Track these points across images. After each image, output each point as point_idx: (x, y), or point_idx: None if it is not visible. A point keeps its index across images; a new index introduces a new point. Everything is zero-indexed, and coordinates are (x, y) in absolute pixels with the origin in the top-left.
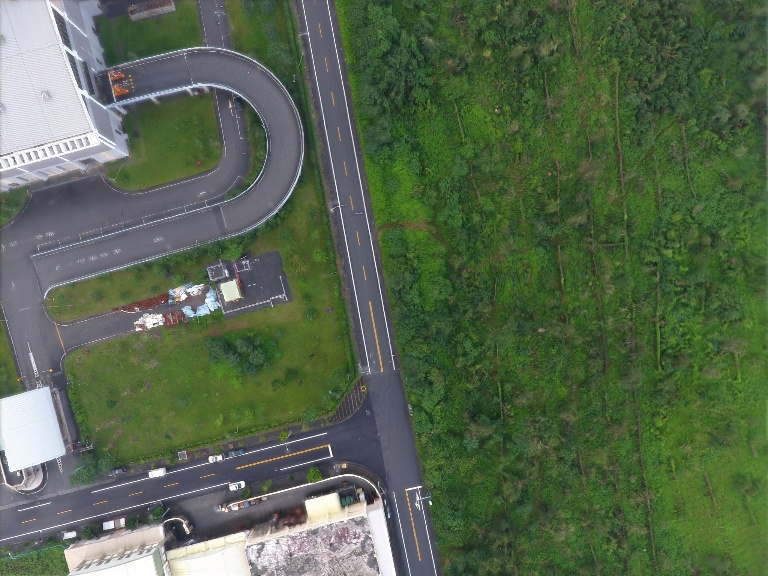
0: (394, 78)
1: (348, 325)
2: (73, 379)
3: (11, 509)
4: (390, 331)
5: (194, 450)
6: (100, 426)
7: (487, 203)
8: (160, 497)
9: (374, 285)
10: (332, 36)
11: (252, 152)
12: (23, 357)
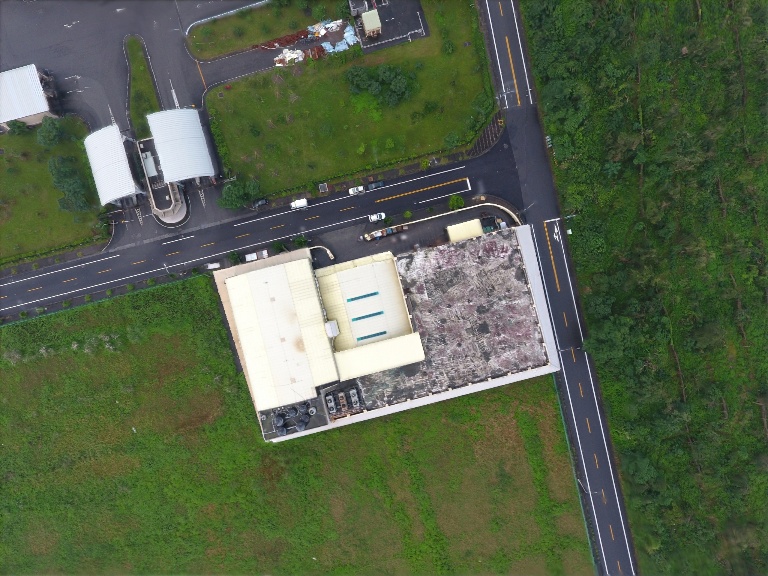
0: None
1: (486, 58)
2: (215, 113)
3: (155, 242)
4: (527, 65)
5: (334, 183)
6: None
7: None
8: (301, 230)
9: (510, 20)
10: None
11: None
12: (165, 94)
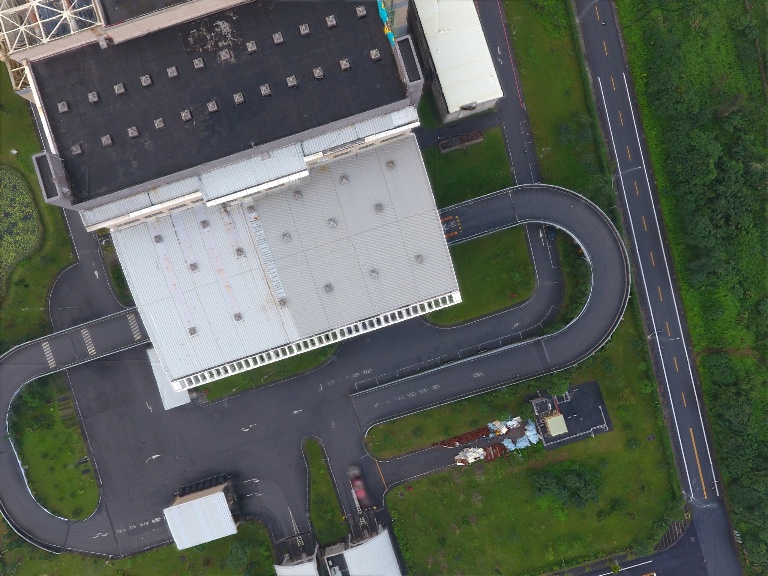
0: (725, 207)
1: (671, 453)
2: (398, 516)
3: None
4: (712, 457)
5: None
6: (429, 562)
7: None
8: None
9: (694, 411)
10: (641, 159)
11: (565, 281)
12: (346, 495)
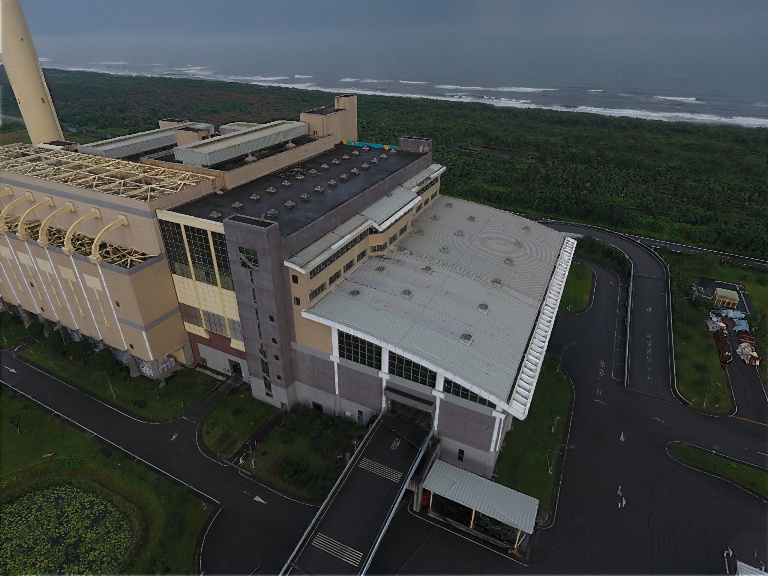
0: None
1: None
2: None
3: None
4: None
5: None
6: None
7: (689, 207)
8: None
9: None
10: None
11: (590, 256)
12: None
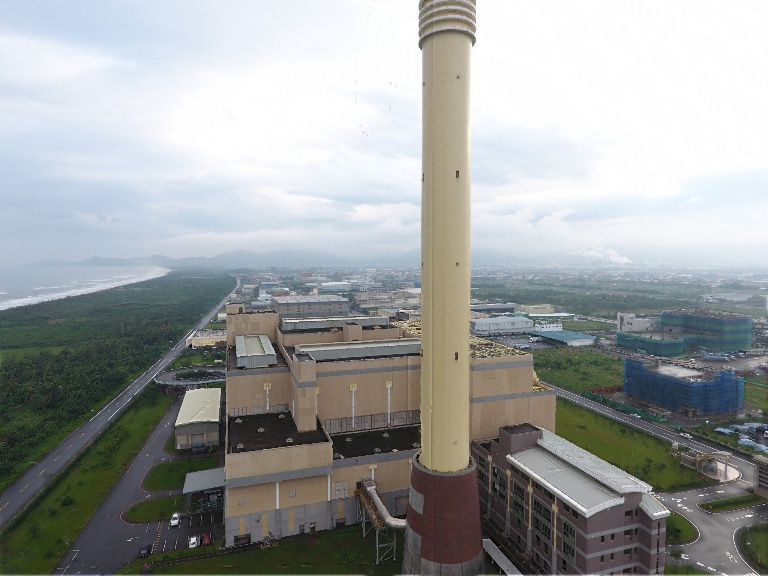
0: None
1: None
2: None
3: None
4: None
5: None
6: None
7: None
8: None
9: None
10: None
11: None
12: None
